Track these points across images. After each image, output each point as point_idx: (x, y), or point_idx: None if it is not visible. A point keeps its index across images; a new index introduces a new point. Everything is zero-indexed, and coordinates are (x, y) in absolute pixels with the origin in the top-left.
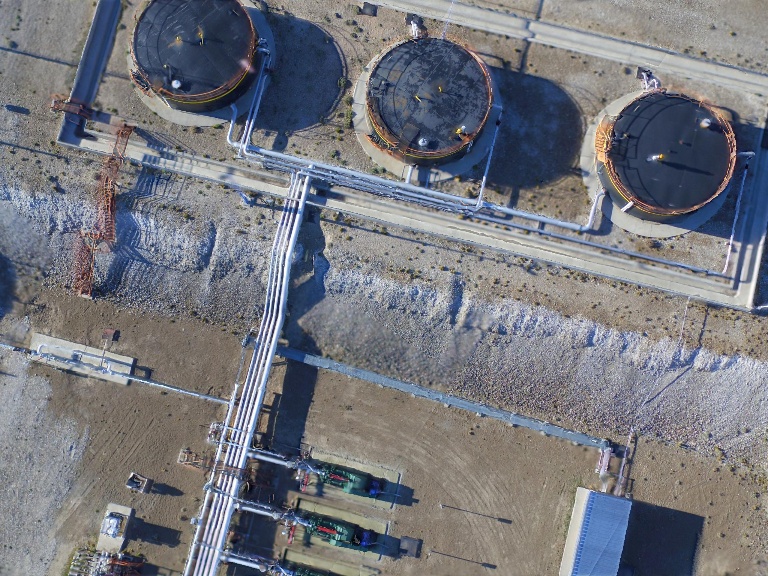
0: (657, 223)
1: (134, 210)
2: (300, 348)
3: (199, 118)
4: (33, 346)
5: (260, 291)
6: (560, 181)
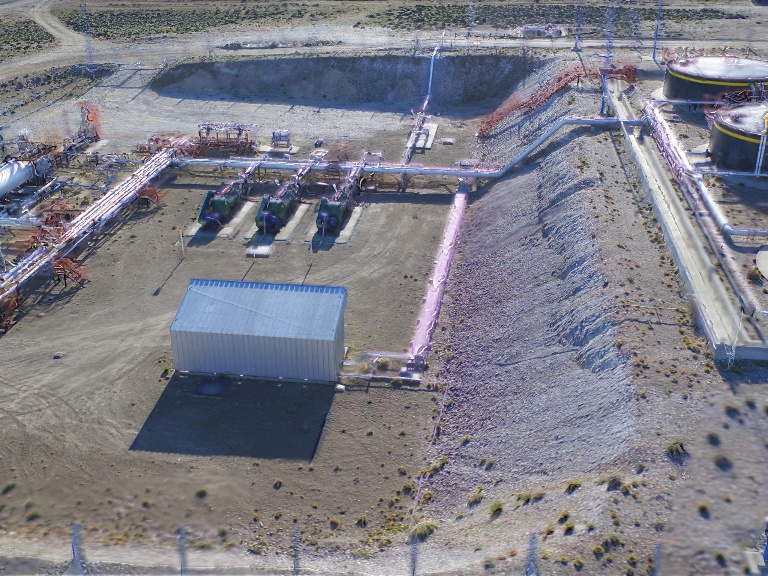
0: None
1: None
2: None
3: None
4: None
5: None
6: None
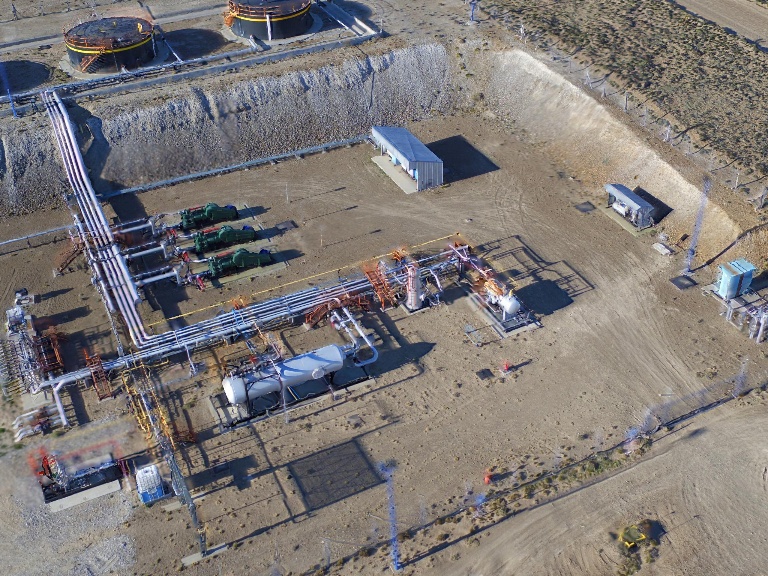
0: (294, 37)
1: None
2: None
3: None
4: None
5: (59, 170)
6: (223, 47)
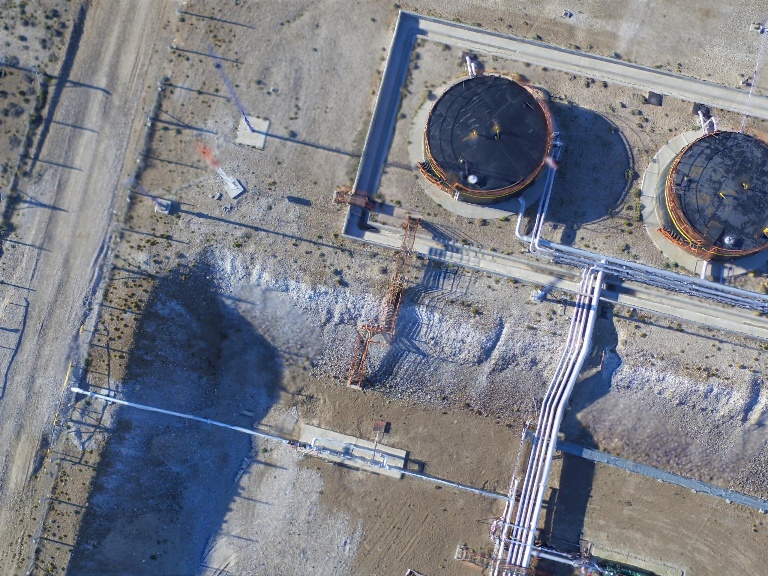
0: None
1: (419, 304)
2: (577, 441)
3: (485, 210)
4: (303, 438)
5: (540, 385)
6: None
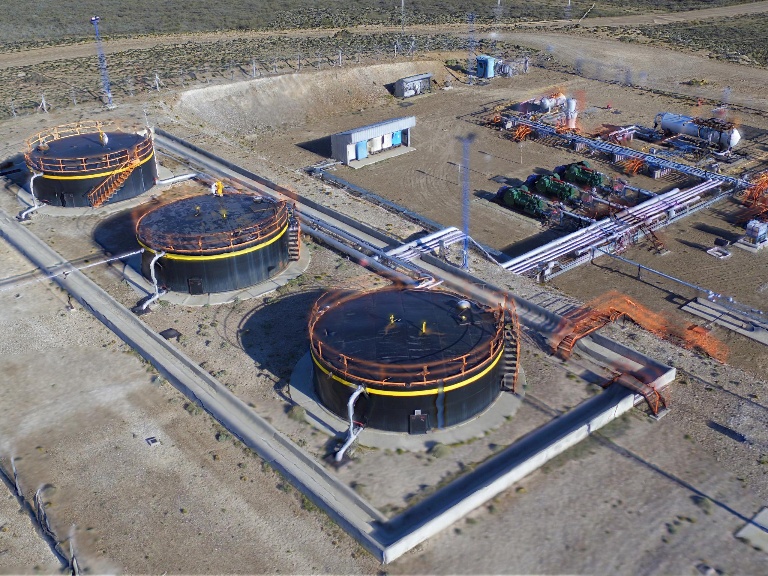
0: None
1: None
2: None
3: None
4: None
5: None
6: None
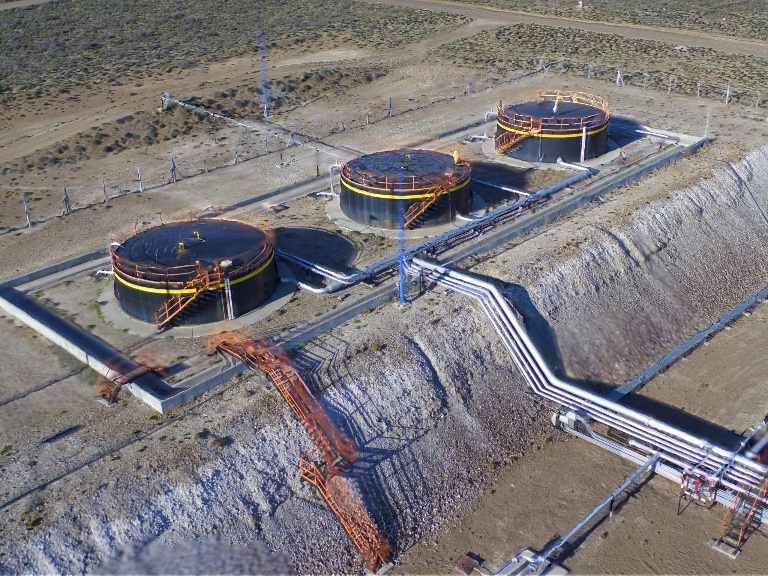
0: (604, 155)
1: (324, 391)
2: (603, 397)
3: (267, 307)
4: None
5: (511, 376)
6: (534, 177)
